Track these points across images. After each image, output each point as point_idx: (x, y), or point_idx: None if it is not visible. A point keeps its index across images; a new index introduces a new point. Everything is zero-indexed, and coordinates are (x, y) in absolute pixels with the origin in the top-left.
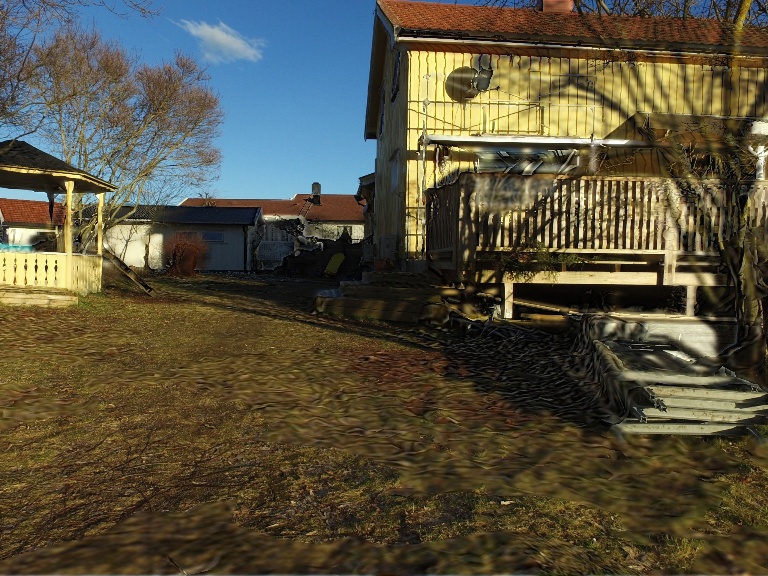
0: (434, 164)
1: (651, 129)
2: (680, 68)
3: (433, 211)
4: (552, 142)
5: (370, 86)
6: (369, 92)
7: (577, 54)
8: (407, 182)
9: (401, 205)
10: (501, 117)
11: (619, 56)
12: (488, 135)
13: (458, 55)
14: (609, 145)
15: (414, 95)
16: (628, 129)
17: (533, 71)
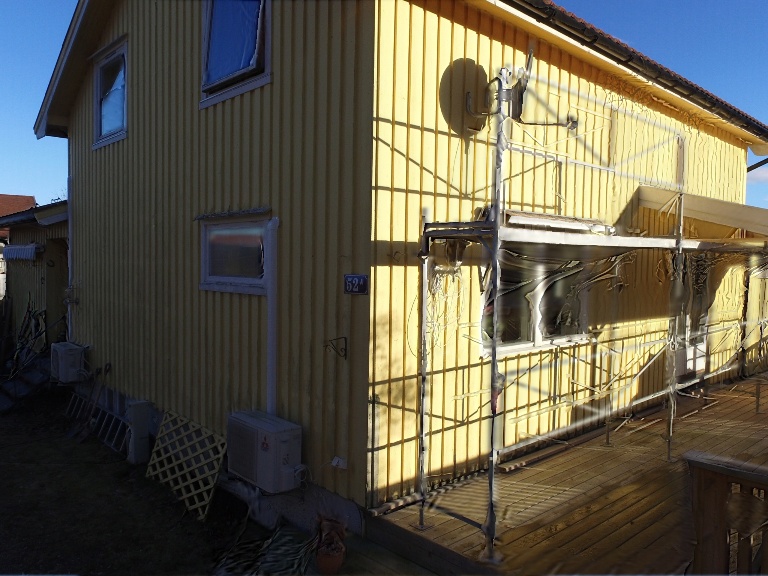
0: (418, 273)
1: (683, 217)
2: (672, 124)
3: (416, 382)
4: (644, 245)
5: (75, 38)
6: (69, 49)
7: (595, 76)
8: (370, 320)
9: (309, 355)
10: (514, 175)
11: (630, 92)
12: (520, 216)
13: (459, 29)
14: (686, 250)
15: (385, 104)
16: (633, 209)
17: (553, 93)
